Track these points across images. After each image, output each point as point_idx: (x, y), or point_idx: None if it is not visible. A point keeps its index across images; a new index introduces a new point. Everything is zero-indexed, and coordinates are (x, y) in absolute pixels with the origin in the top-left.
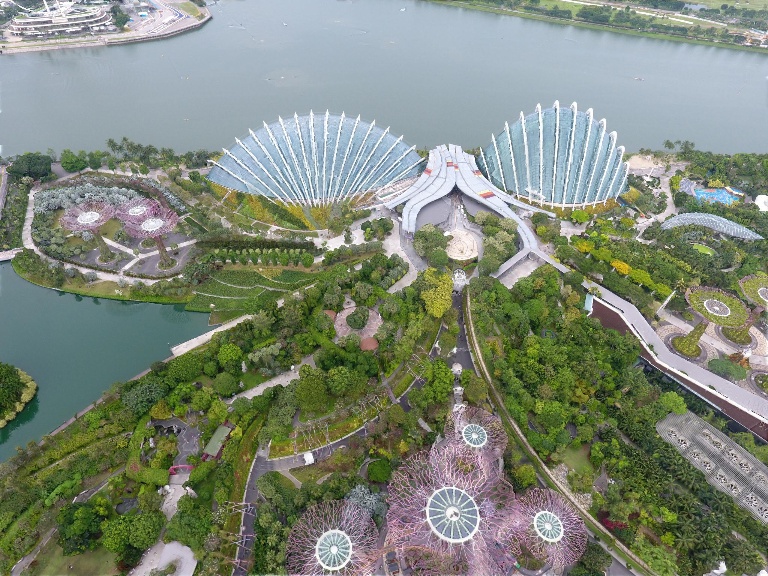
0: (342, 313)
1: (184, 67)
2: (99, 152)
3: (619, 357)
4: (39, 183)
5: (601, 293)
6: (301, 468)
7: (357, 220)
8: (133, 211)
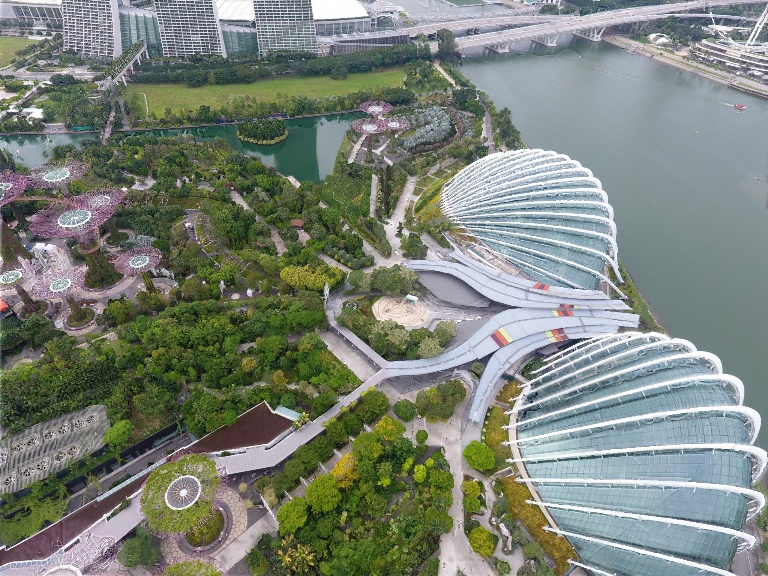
0: (304, 233)
1: (724, 127)
2: (495, 112)
3: (189, 400)
4: (448, 104)
5: (303, 432)
6: None
7: (433, 239)
8: (392, 123)
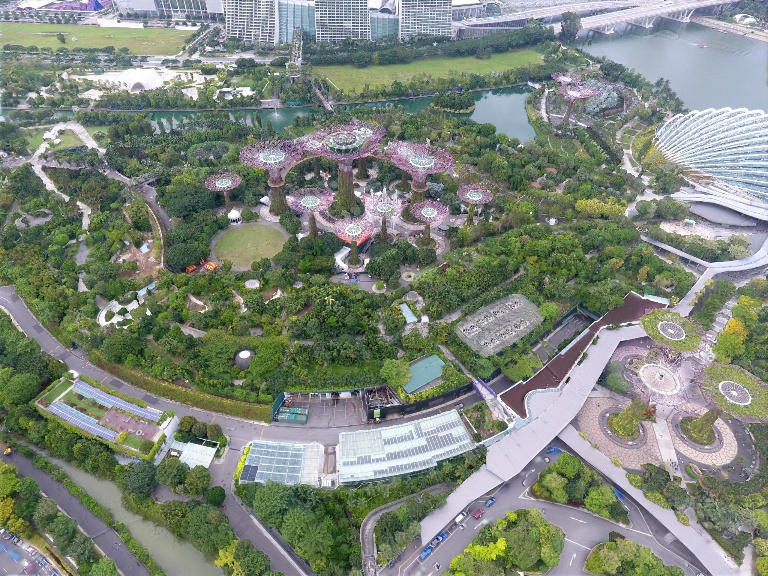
0: None
1: None
2: (649, 82)
3: (584, 289)
4: (600, 77)
5: None
6: (450, 176)
7: None
8: None
